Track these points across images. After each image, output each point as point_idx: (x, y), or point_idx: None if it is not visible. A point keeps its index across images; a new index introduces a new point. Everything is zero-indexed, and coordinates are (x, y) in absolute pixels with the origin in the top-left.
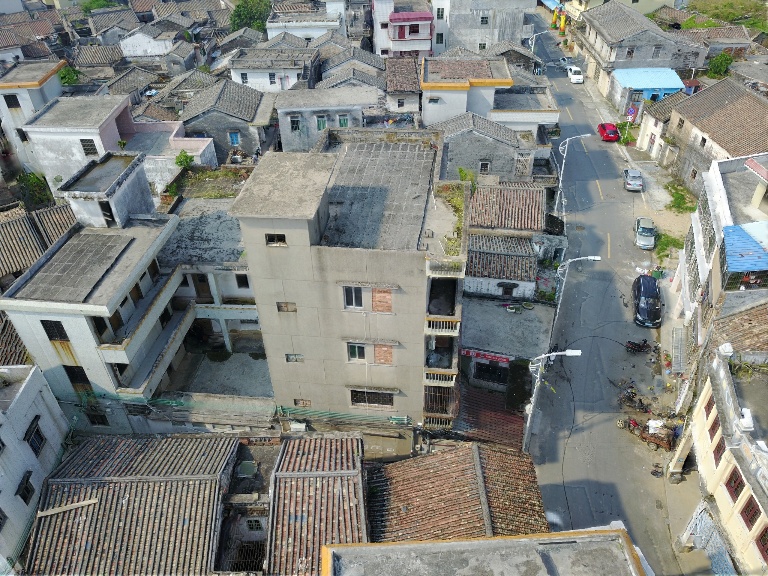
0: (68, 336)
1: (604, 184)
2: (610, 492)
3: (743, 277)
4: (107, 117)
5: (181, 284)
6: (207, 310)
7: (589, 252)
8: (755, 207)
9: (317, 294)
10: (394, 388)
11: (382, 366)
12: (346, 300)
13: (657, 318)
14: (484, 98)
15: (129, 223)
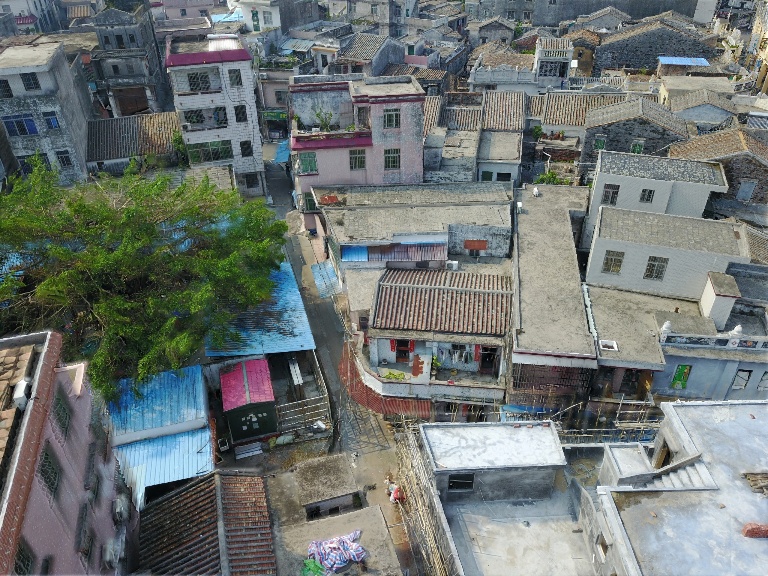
0: None
1: None
2: None
3: None
4: None
5: None
6: None
7: None
8: None
9: None
10: None
11: None
12: None
13: None
14: None
15: None
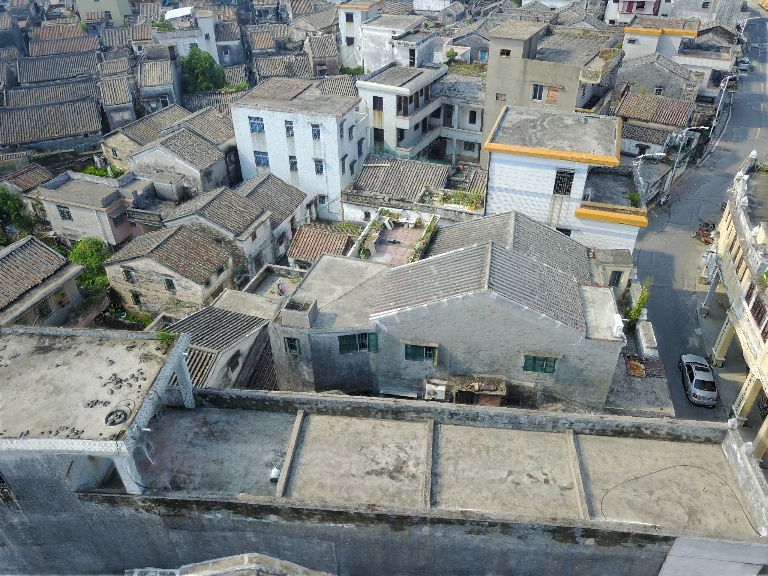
0: (383, 108)
1: (764, 131)
2: (669, 257)
3: None
4: (411, 25)
5: (436, 117)
6: (448, 131)
7: (725, 163)
8: None
9: (519, 89)
10: None
11: None
12: (533, 95)
13: None
14: (672, 44)
15: (421, 67)
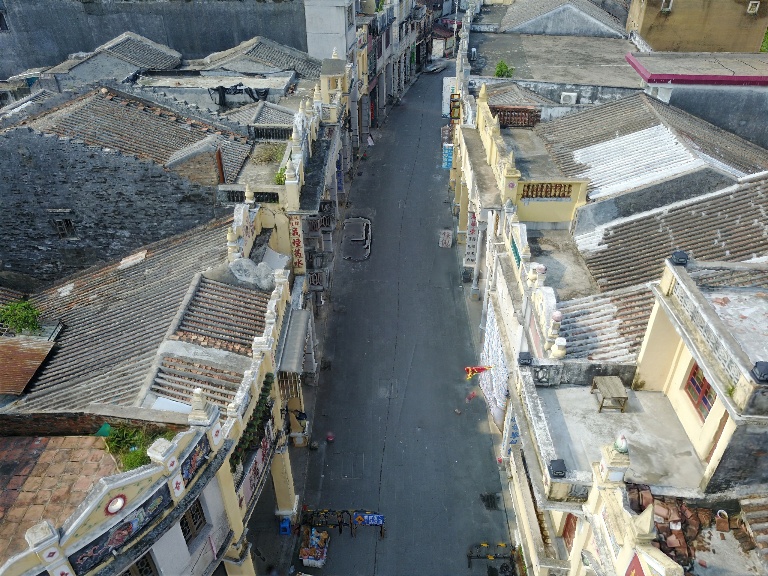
0: None
1: None
2: None
3: None
4: None
5: None
6: None
7: None
8: None
9: None
10: None
11: None
12: None
13: None
14: None
15: None
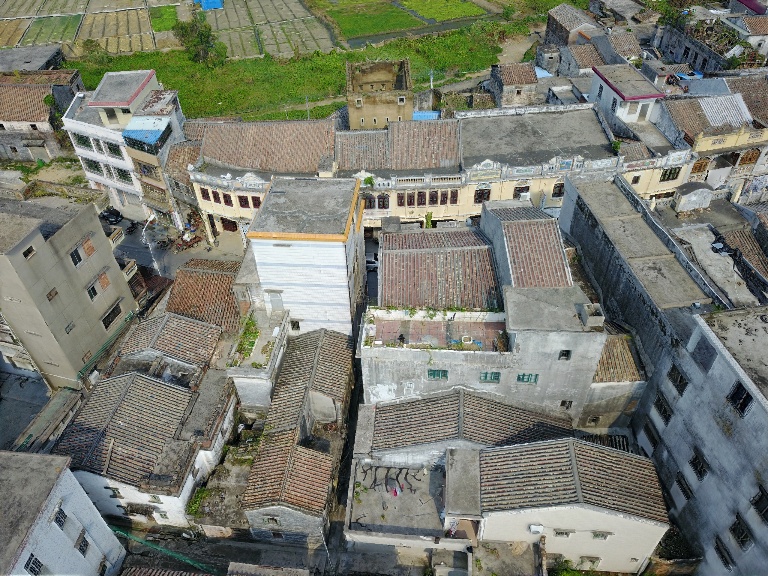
0: None
1: None
2: None
3: (157, 145)
4: None
5: None
6: None
7: None
8: (108, 124)
9: (61, 271)
10: (118, 298)
11: (107, 289)
12: (73, 263)
13: (119, 213)
14: None
15: None
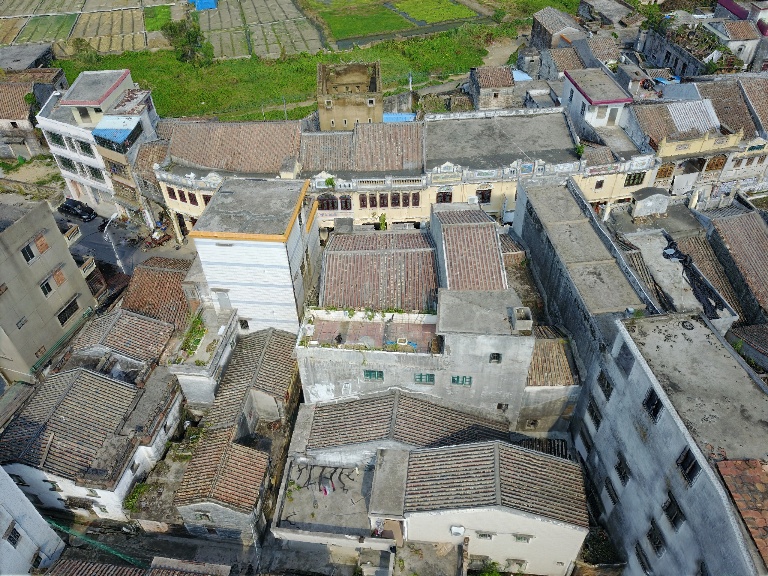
0: None
1: None
2: None
3: (125, 144)
4: None
5: None
6: None
7: None
8: (81, 123)
9: (12, 267)
10: (74, 294)
11: (62, 285)
12: (25, 259)
13: (92, 211)
14: None
15: None
